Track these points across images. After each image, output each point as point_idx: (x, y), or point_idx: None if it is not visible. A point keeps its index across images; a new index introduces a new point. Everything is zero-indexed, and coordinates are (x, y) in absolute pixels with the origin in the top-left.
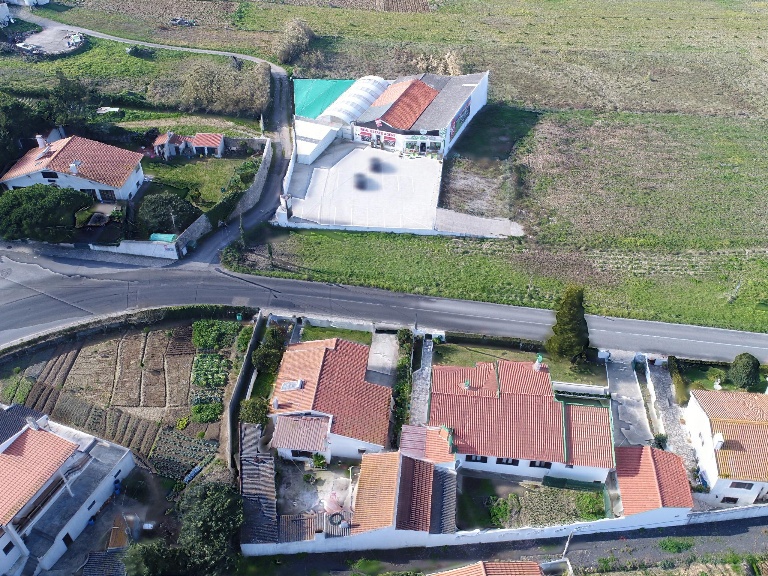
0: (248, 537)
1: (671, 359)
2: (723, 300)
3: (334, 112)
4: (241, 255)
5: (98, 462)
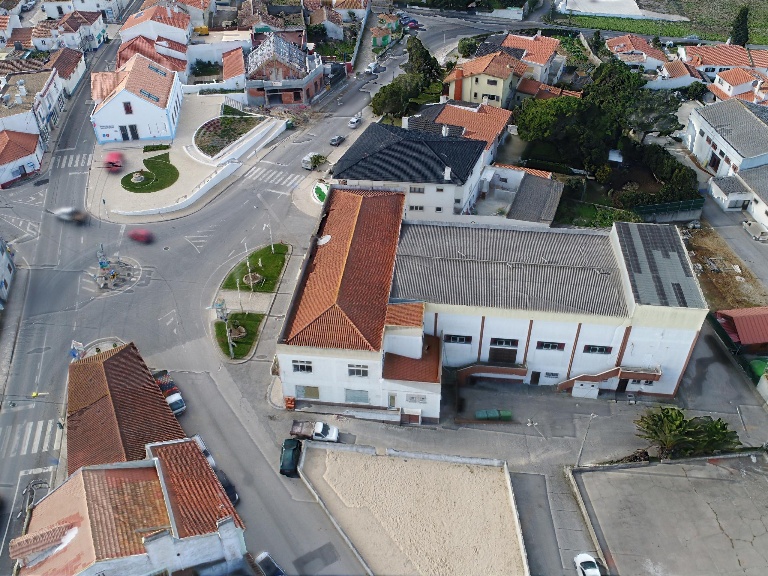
0: None
1: None
2: None
3: None
4: None
5: (555, 60)
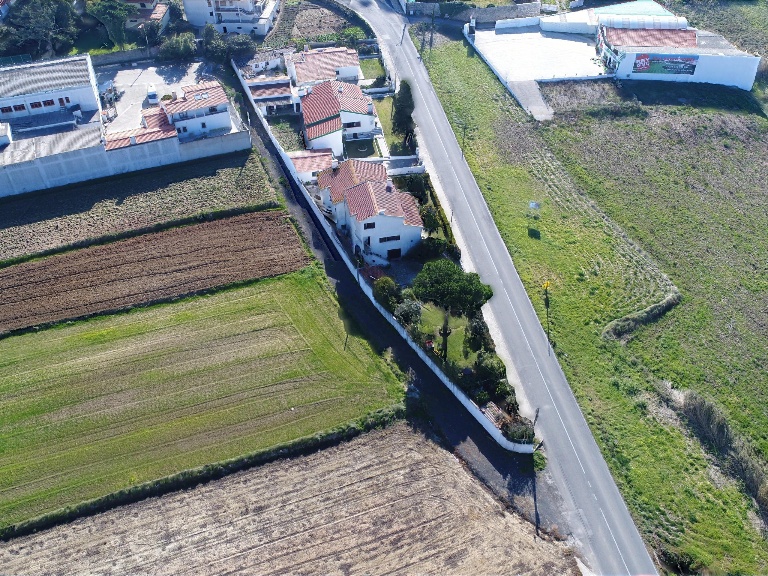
0: (236, 58)
1: (425, 173)
2: (528, 212)
3: (604, 15)
4: (426, 29)
5: None
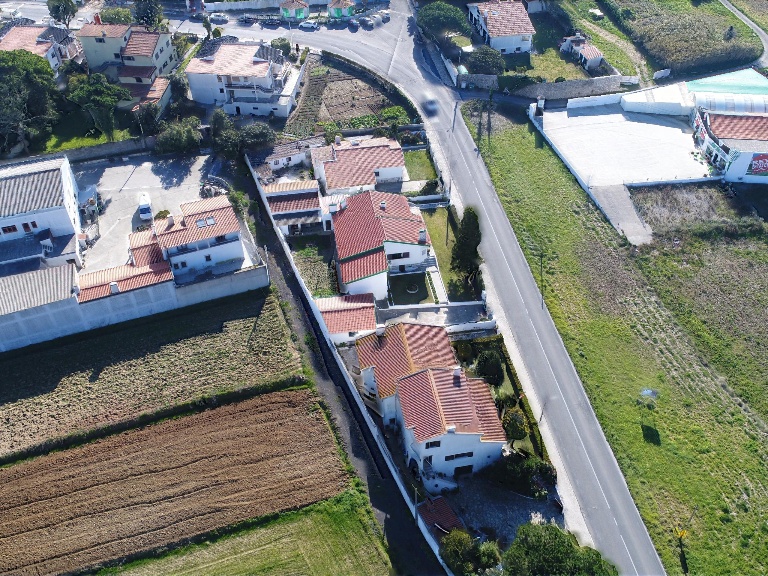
0: (250, 154)
1: None
2: (638, 396)
3: (702, 93)
4: None
5: (278, 100)
